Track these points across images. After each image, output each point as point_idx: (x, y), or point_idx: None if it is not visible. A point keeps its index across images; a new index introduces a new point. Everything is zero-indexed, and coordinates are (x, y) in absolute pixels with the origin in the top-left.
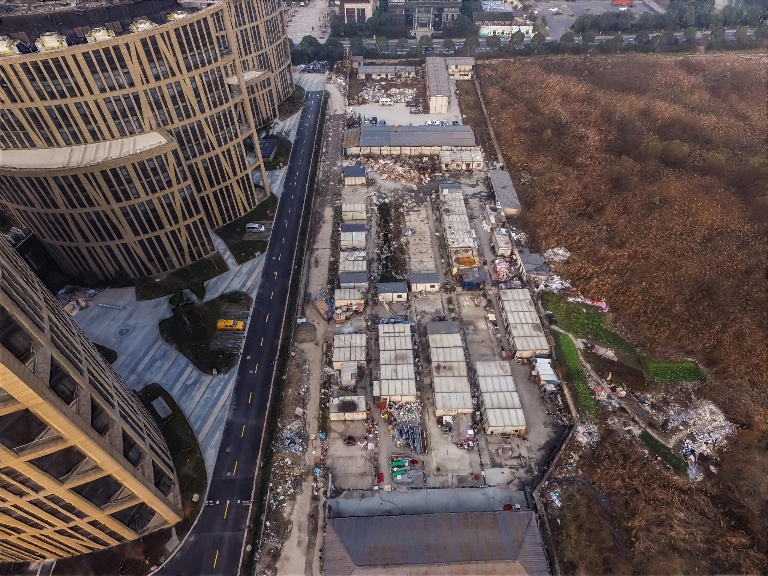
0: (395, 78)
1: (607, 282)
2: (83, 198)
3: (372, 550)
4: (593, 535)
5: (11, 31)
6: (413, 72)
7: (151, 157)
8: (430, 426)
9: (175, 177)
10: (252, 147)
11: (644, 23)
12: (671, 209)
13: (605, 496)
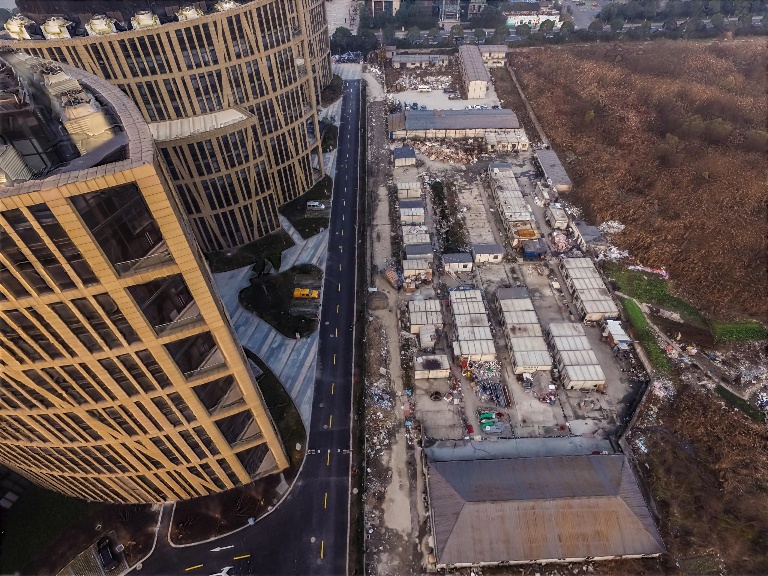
0: (429, 67)
1: (666, 251)
2: (169, 171)
3: (478, 488)
4: (682, 477)
5: (108, 10)
6: (447, 60)
7: (233, 131)
8: (511, 383)
9: (252, 152)
10: None
11: (670, 11)
12: (720, 183)
13: (688, 444)
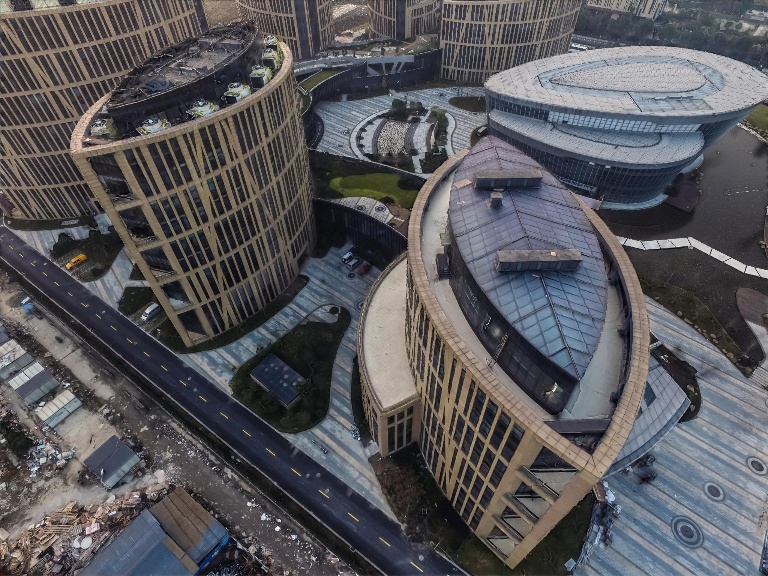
0: None
1: None
2: None
3: None
4: None
5: None
6: None
7: None
8: None
9: None
10: (309, 372)
11: None
12: None
13: None
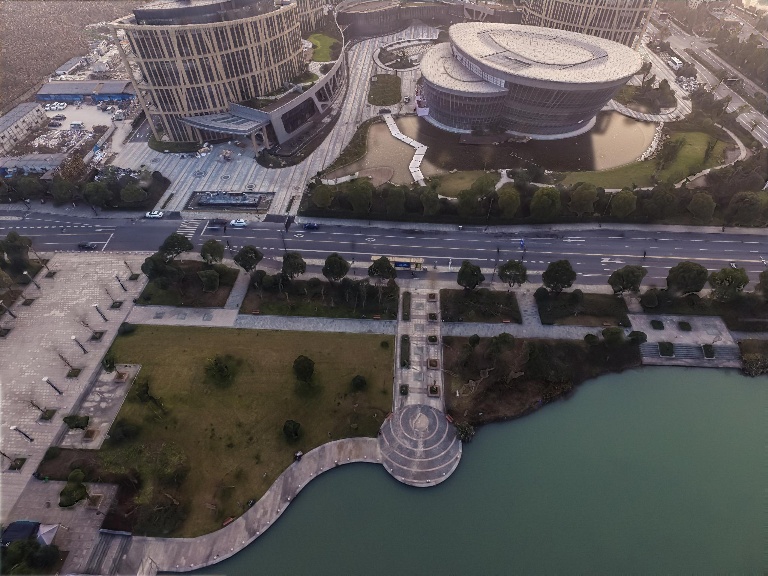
0: None
1: None
2: None
3: None
4: None
5: None
6: None
7: None
8: None
9: None
10: None
11: None
12: (1, 53)
13: None
